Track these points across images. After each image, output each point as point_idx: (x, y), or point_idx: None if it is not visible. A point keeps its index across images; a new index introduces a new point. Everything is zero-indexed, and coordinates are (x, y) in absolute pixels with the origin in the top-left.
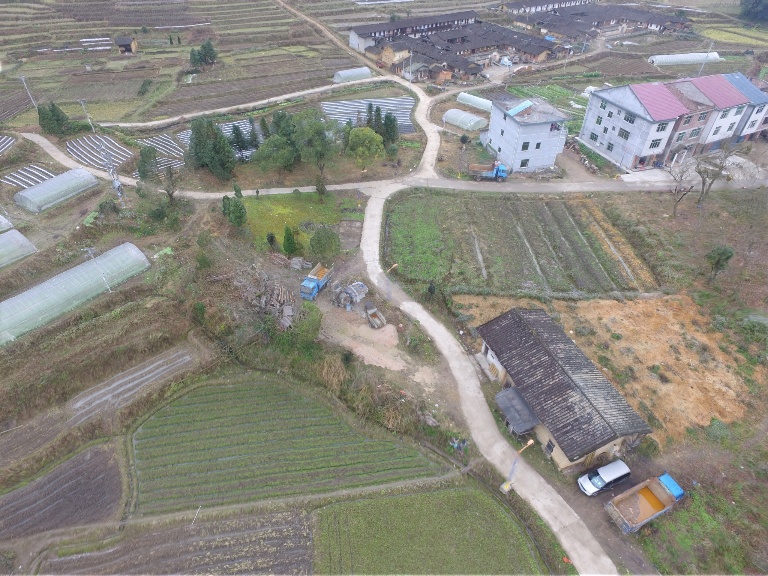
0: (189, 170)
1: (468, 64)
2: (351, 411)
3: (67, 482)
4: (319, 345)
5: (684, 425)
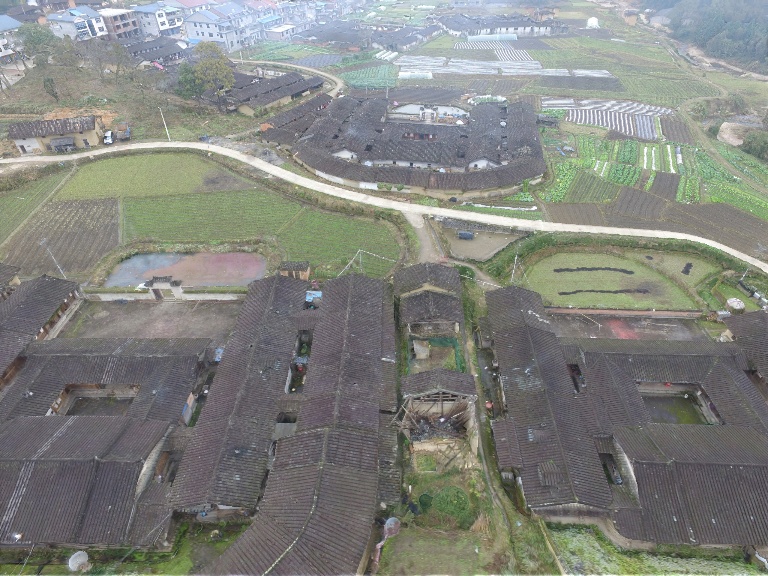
0: None
1: None
2: (10, 190)
3: None
4: None
5: (109, 123)
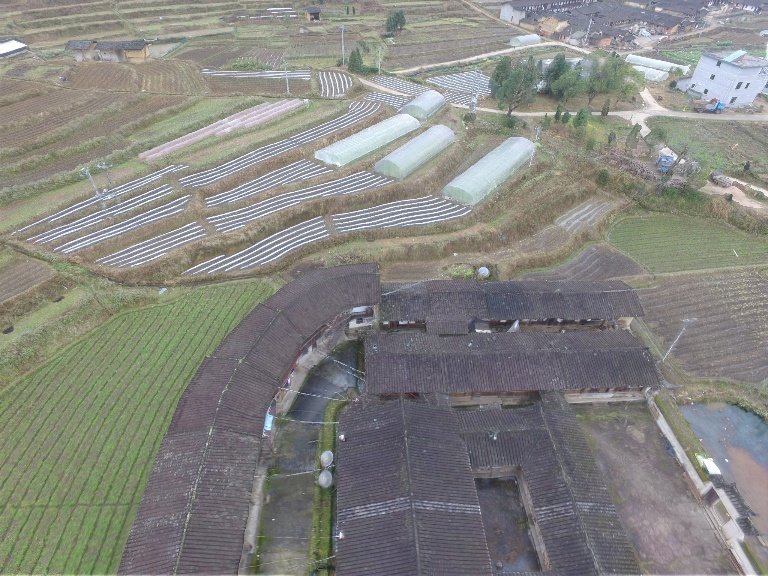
0: (493, 98)
1: (624, 32)
2: (741, 229)
3: (595, 259)
4: (701, 193)
5: None
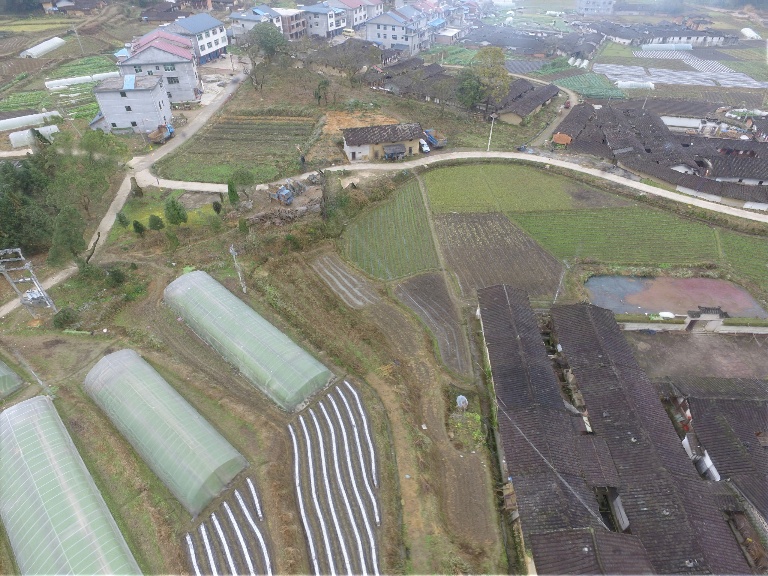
0: None
1: None
2: None
3: None
4: None
5: None
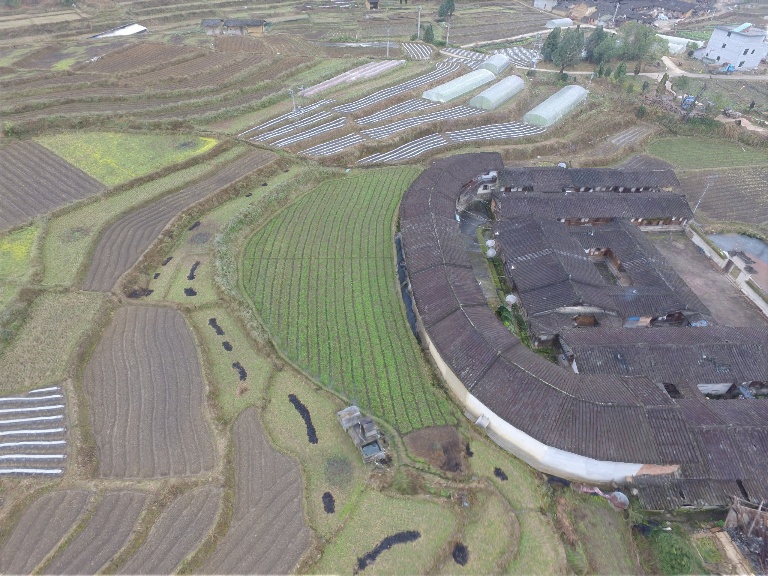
0: (545, 62)
1: (646, 16)
2: (747, 145)
3: (640, 162)
4: None
5: None
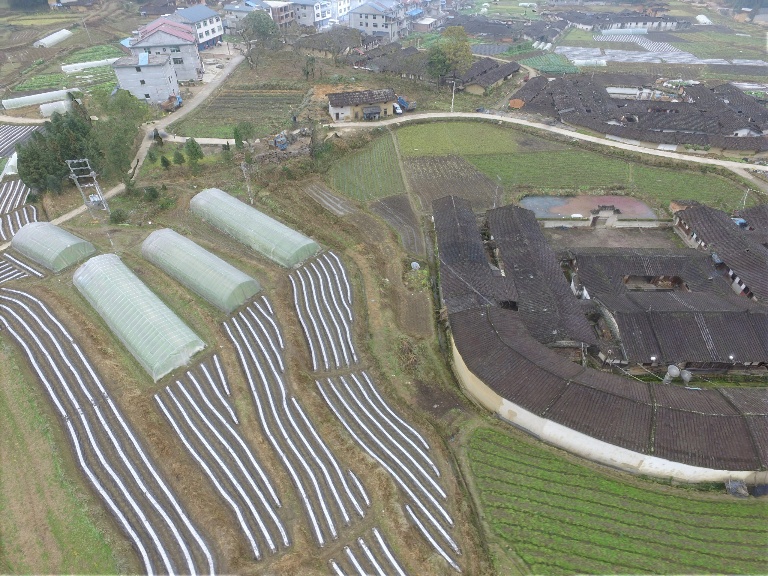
0: (60, 194)
1: None
2: None
3: None
4: (325, 143)
5: None
